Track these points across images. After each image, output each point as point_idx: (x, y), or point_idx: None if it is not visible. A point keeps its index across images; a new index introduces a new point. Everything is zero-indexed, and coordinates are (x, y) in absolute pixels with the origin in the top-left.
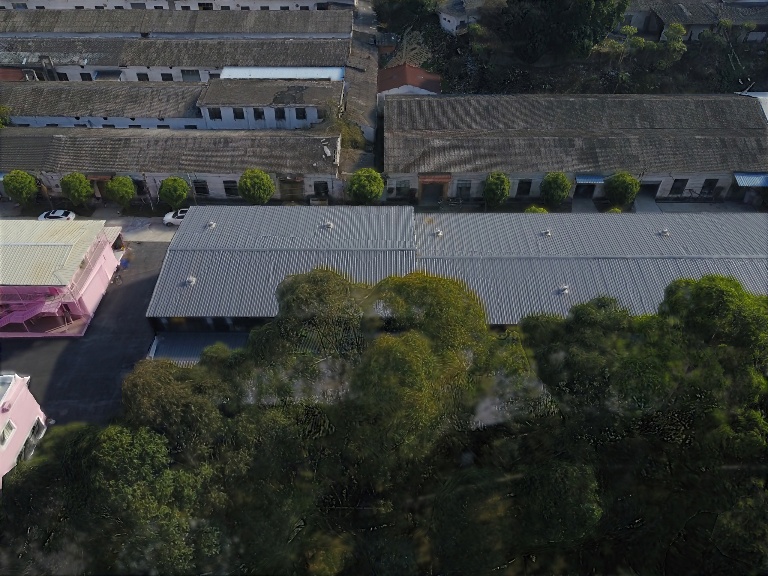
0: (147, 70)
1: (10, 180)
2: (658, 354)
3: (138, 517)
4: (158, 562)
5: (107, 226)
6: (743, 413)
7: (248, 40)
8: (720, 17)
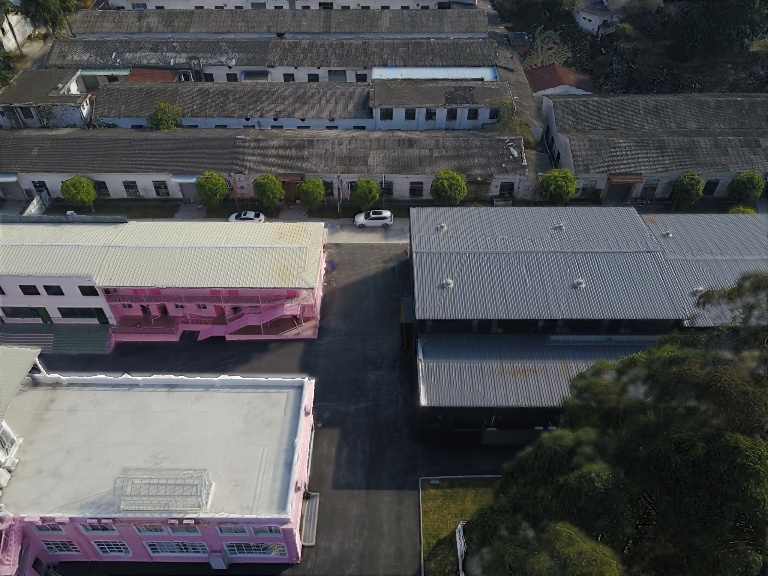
0: (294, 70)
1: (205, 182)
2: None
3: None
4: (737, 569)
5: None
6: None
7: (393, 40)
8: None
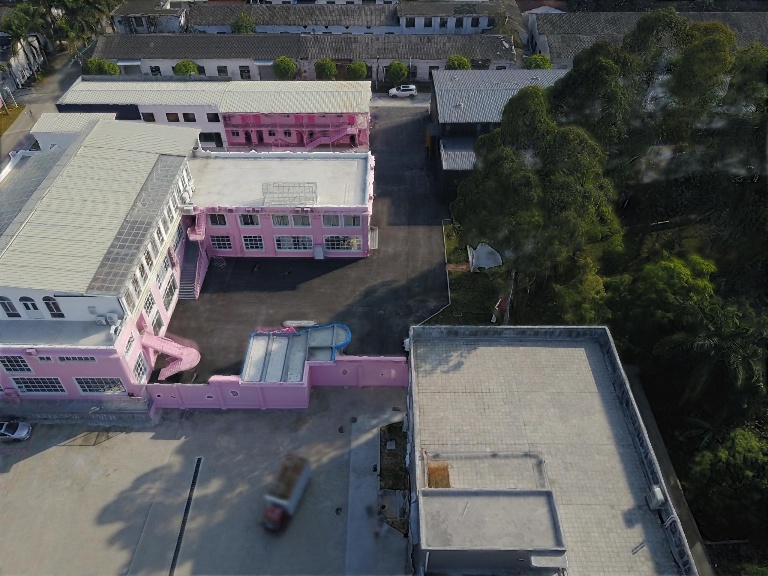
0: None
1: (280, 63)
2: None
3: (617, 94)
4: (605, 135)
5: None
6: None
7: None
8: None
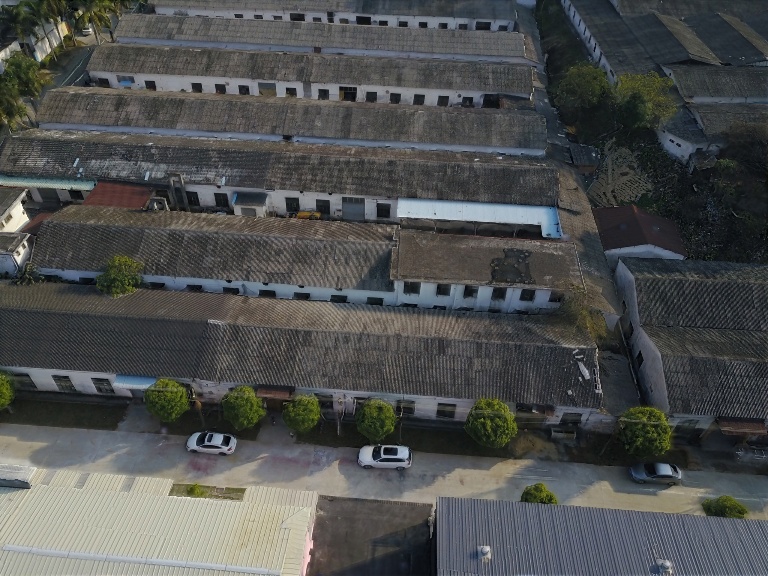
0: (299, 195)
1: (156, 397)
2: None
3: None
4: None
5: (281, 462)
6: None
7: (426, 160)
8: None
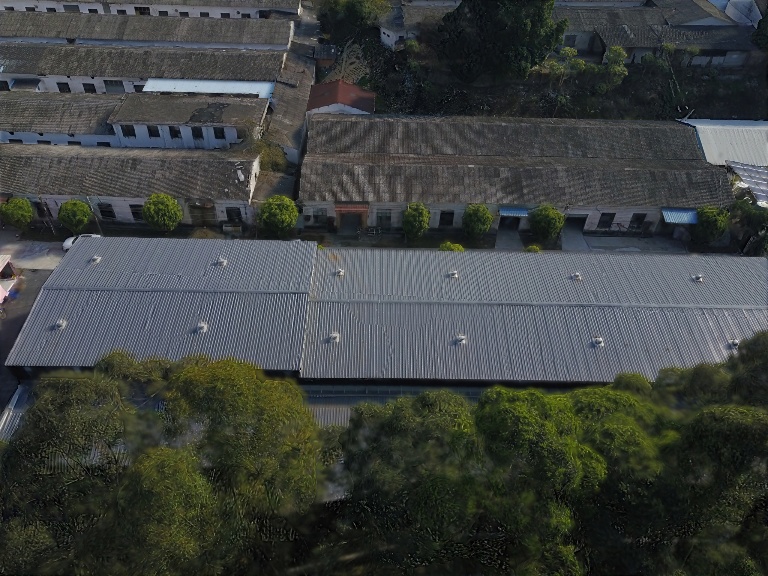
0: (67, 79)
1: None
2: (464, 475)
3: None
4: None
5: (2, 251)
6: (548, 550)
7: (176, 50)
8: (663, 40)
